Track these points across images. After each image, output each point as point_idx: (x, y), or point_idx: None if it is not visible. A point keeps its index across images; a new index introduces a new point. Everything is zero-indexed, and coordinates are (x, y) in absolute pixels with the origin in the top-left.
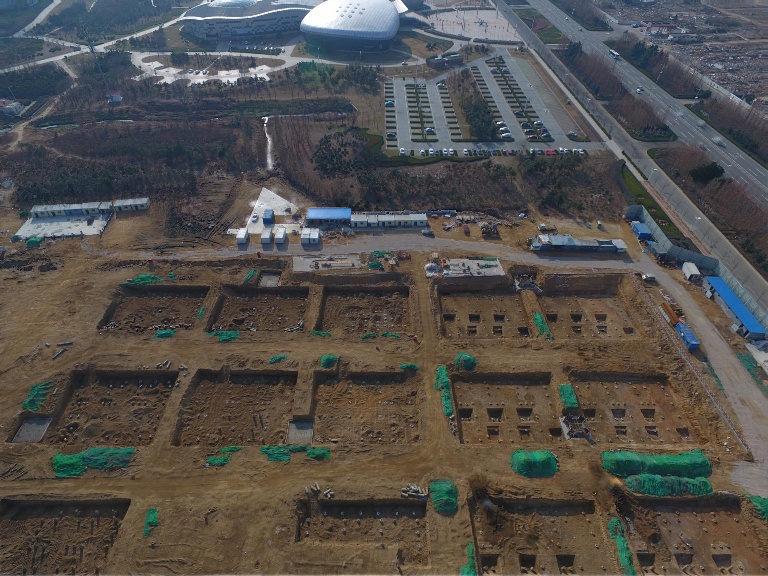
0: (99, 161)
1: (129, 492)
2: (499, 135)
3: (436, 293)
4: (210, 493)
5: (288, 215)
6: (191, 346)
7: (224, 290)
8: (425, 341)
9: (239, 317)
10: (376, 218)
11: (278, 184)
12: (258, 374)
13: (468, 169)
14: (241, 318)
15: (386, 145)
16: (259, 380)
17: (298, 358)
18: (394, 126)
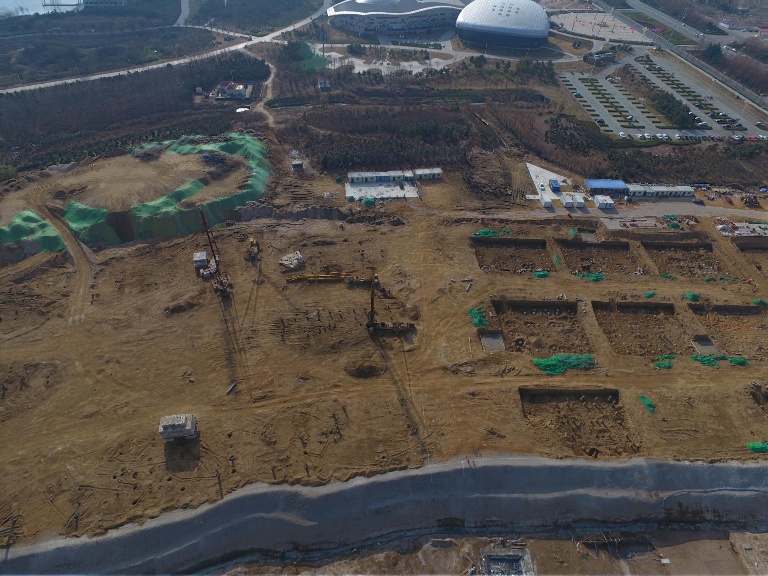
0: (361, 138)
1: (613, 385)
2: (696, 124)
3: (738, 249)
4: (676, 386)
5: (567, 185)
6: (570, 284)
7: (557, 243)
8: (759, 284)
9: (584, 264)
10: (651, 188)
11: (536, 160)
12: (639, 306)
13: (693, 151)
14: (587, 265)
15: (603, 130)
16: (642, 311)
17: (666, 294)
18: (597, 114)
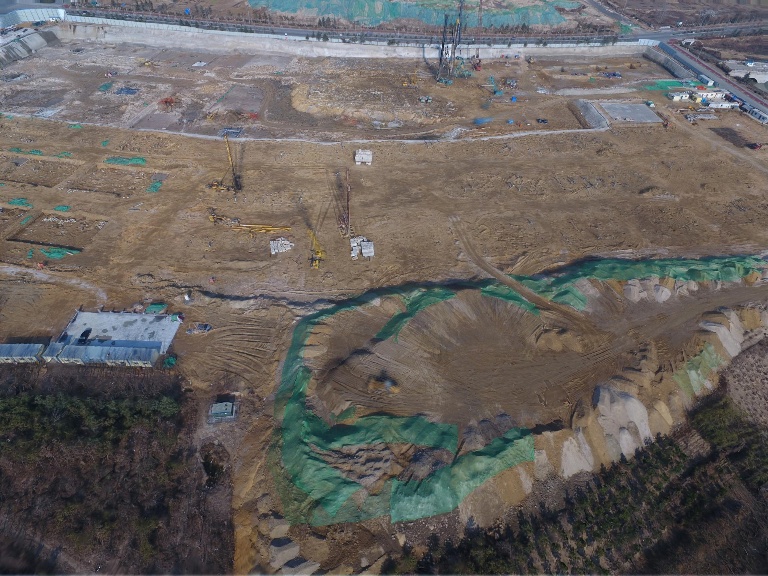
0: (25, 532)
1: None
2: None
3: None
4: (76, 146)
5: None
6: (48, 200)
7: None
8: None
9: (2, 221)
10: None
11: None
12: None
13: None
14: (1, 220)
15: None
16: None
17: None
18: None
